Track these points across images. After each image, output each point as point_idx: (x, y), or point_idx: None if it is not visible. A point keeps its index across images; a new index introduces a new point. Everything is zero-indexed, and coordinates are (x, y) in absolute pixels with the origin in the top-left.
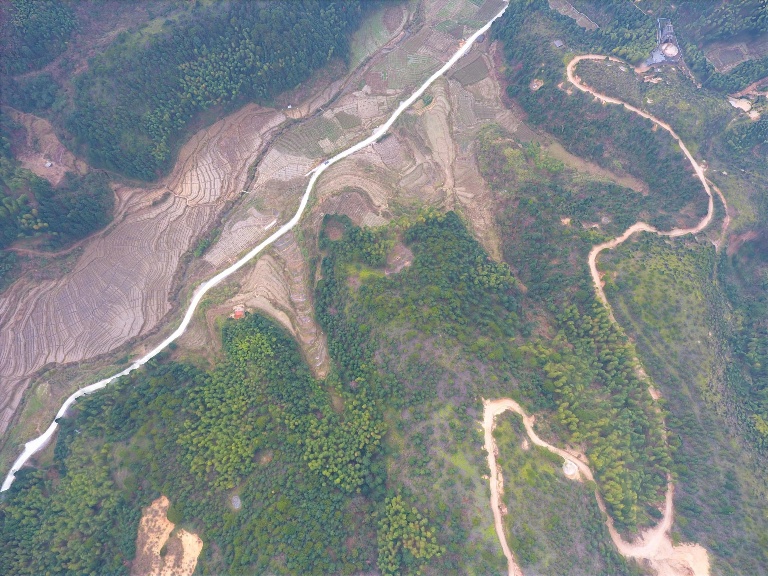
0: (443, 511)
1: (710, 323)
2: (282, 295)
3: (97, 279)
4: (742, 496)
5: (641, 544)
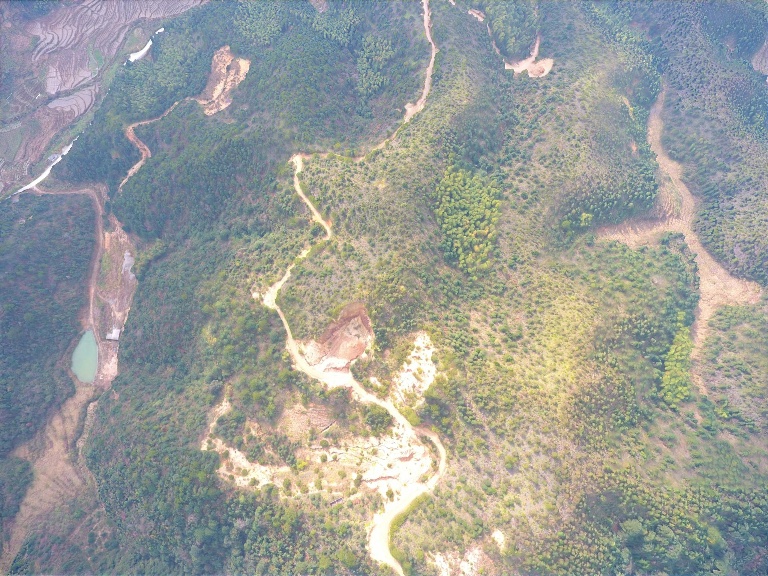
0: (396, 35)
1: None
2: None
3: None
4: (576, 31)
5: (517, 66)
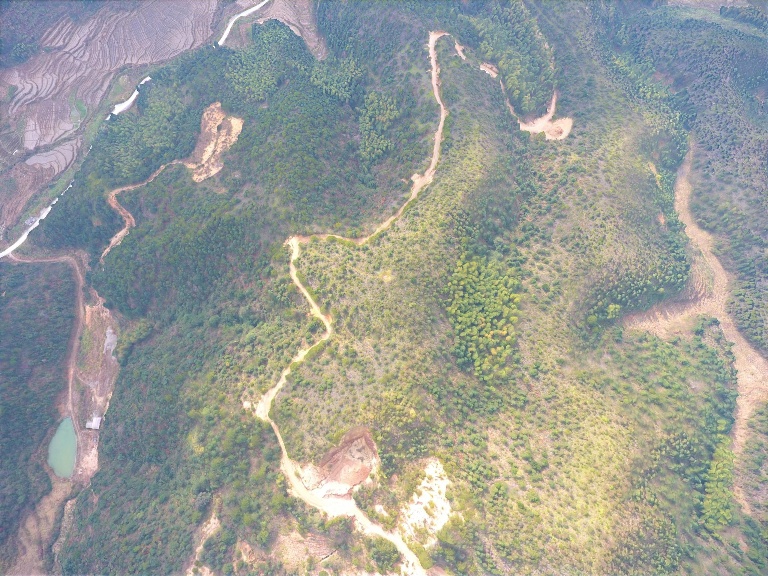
0: (401, 93)
1: (587, 0)
2: (294, 19)
3: (159, 13)
4: (597, 88)
5: (532, 125)
